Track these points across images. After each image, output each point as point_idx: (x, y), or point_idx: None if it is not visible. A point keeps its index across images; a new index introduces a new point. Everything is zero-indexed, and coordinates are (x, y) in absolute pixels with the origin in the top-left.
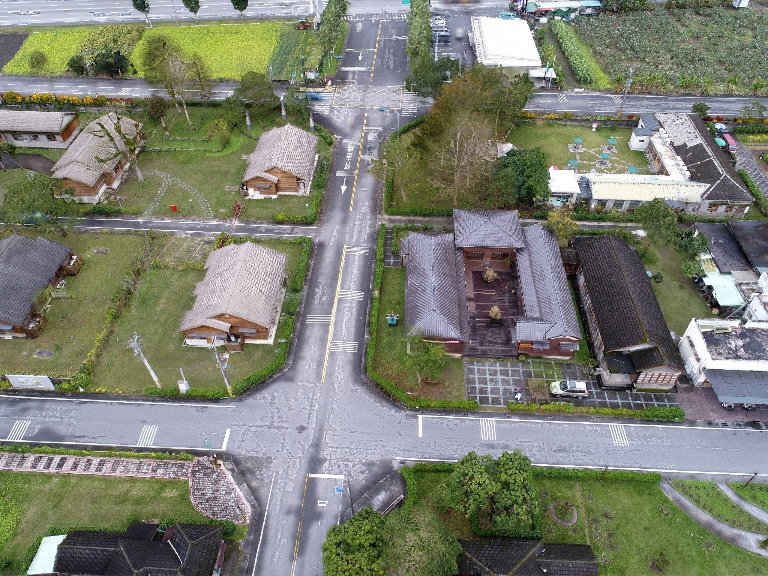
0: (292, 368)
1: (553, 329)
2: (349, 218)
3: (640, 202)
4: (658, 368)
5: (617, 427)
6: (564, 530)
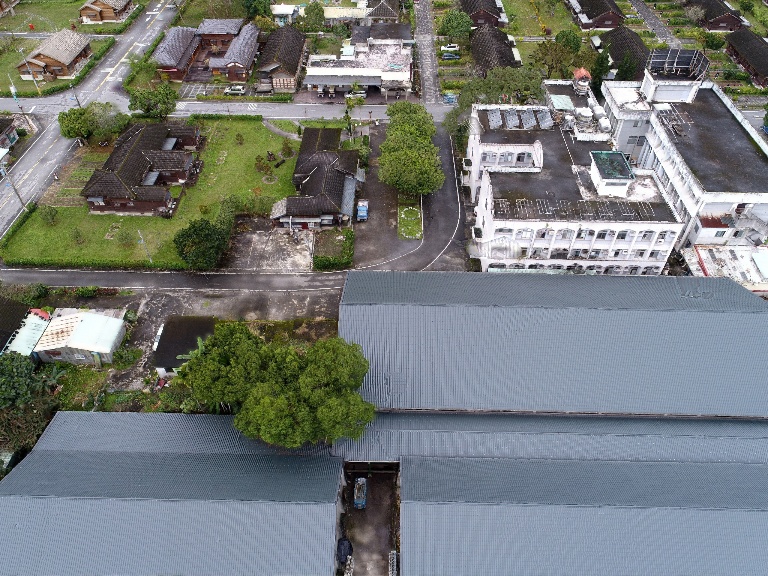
0: (81, 86)
1: (229, 61)
2: (144, 31)
3: (330, 20)
4: (281, 75)
5: (254, 104)
6: (200, 134)
